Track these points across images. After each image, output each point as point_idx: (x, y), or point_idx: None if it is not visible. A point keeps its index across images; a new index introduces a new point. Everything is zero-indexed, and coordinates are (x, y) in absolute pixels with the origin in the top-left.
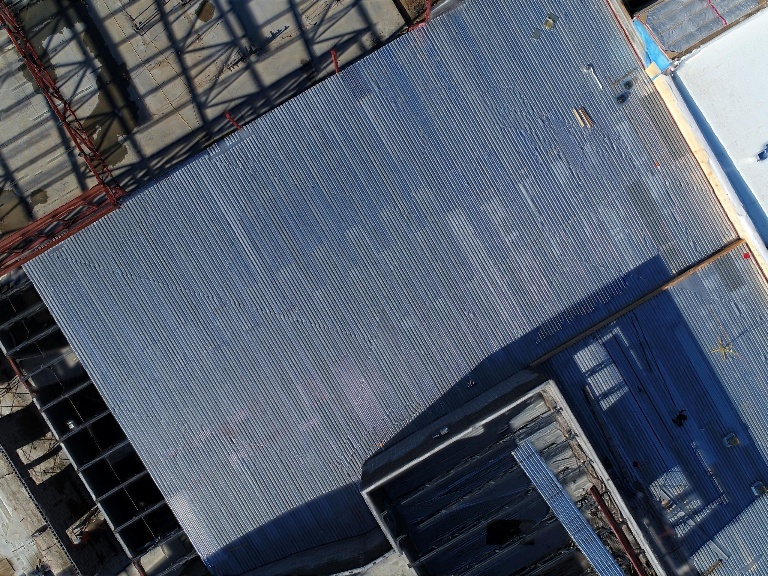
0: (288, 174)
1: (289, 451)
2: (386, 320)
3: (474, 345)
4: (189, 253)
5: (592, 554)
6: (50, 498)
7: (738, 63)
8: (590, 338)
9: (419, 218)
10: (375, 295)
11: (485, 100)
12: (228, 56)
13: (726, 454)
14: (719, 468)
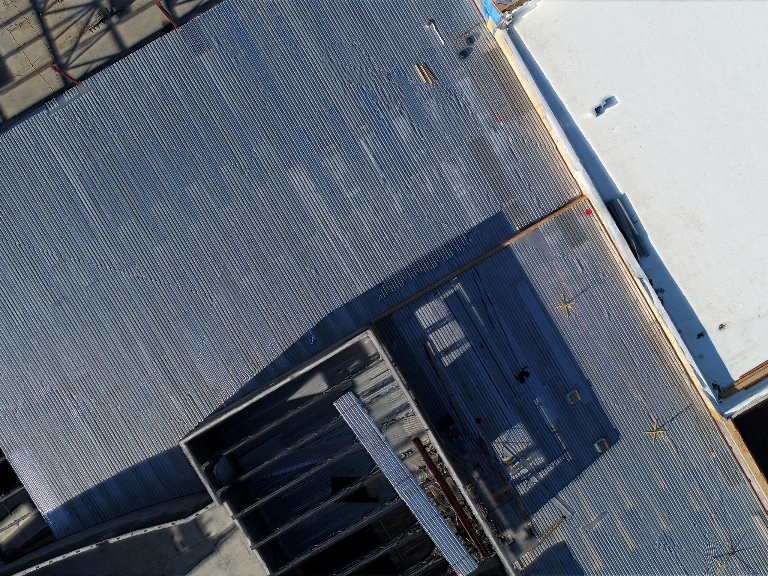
0: (127, 129)
1: (130, 407)
2: (227, 276)
3: (316, 301)
4: (28, 208)
5: (416, 506)
6: None
7: (576, 18)
8: (431, 294)
9: (260, 174)
10: (216, 251)
11: (330, 57)
12: (89, 17)
13: (569, 411)
14: (562, 425)
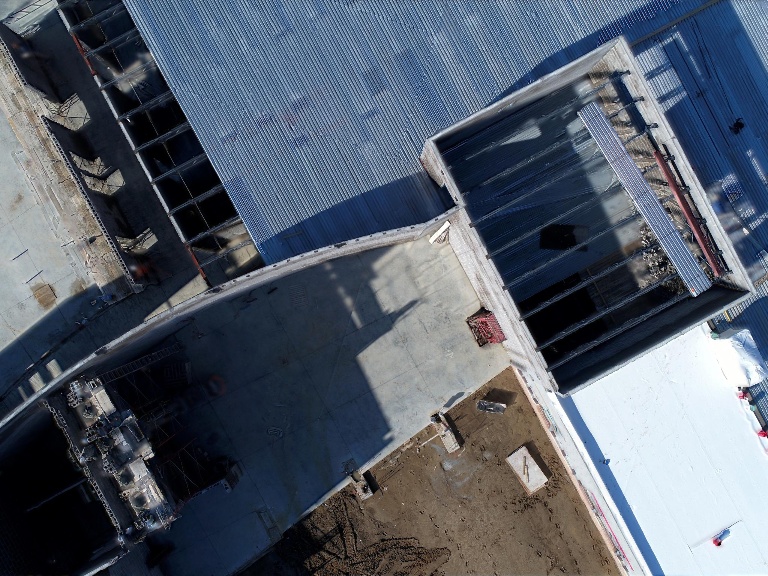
0: None
1: (347, 141)
2: (449, 15)
3: (535, 45)
4: None
5: (654, 220)
6: (100, 204)
7: None
8: (650, 41)
9: None
10: None
11: None
12: None
13: None
14: None
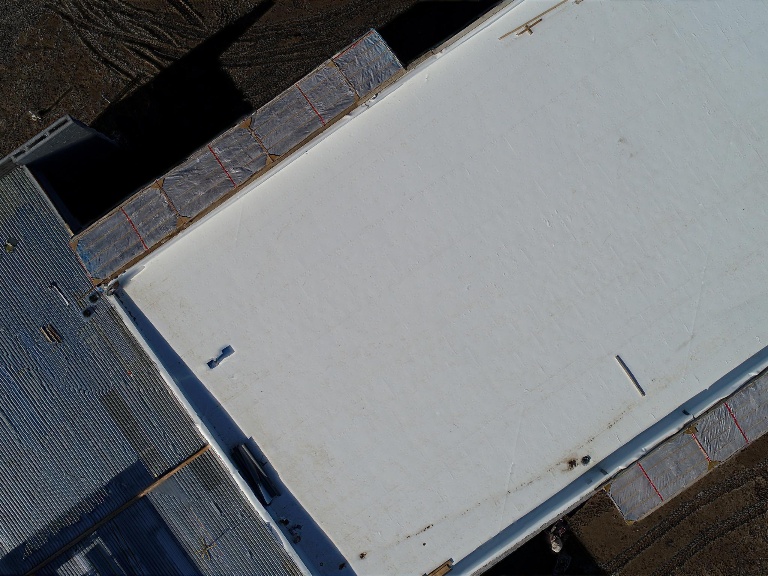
0: None
1: None
2: None
3: None
4: None
5: None
6: None
7: (184, 275)
8: (72, 550)
9: None
10: None
11: None
12: None
13: None
14: None
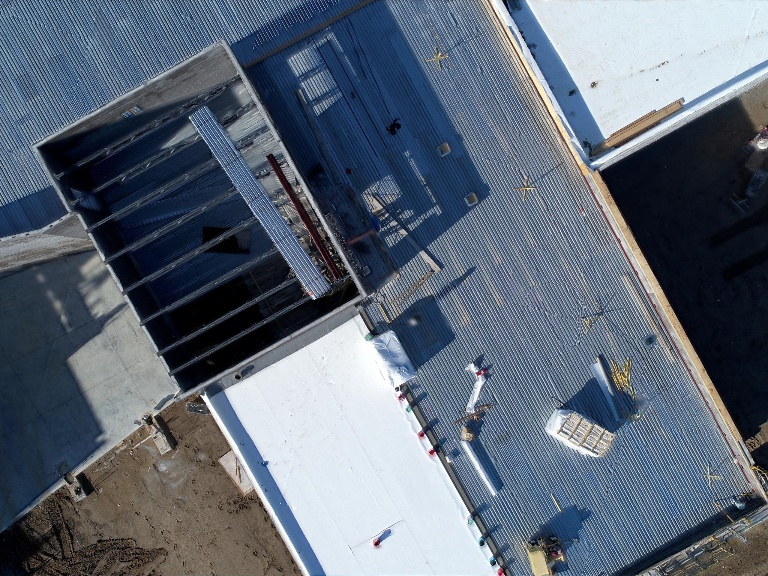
0: None
1: (3, 148)
2: (102, 20)
3: (190, 48)
4: None
5: (269, 224)
6: None
7: None
8: (305, 43)
9: None
10: None
11: None
12: None
13: (440, 164)
14: (433, 178)
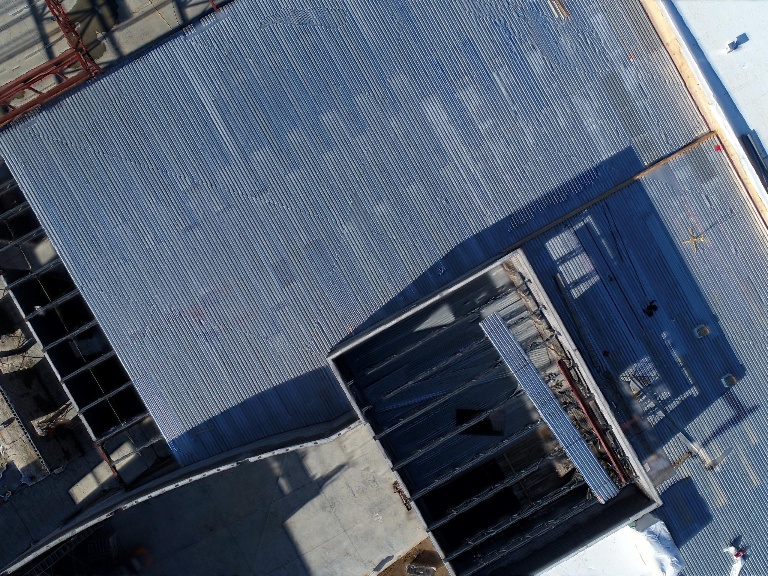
0: (263, 56)
1: (258, 334)
2: (358, 204)
3: (446, 232)
4: (162, 132)
5: (559, 429)
6: (16, 388)
7: None
8: (562, 226)
9: (393, 104)
10: (348, 179)
11: None
12: None
13: (696, 346)
14: (689, 360)
